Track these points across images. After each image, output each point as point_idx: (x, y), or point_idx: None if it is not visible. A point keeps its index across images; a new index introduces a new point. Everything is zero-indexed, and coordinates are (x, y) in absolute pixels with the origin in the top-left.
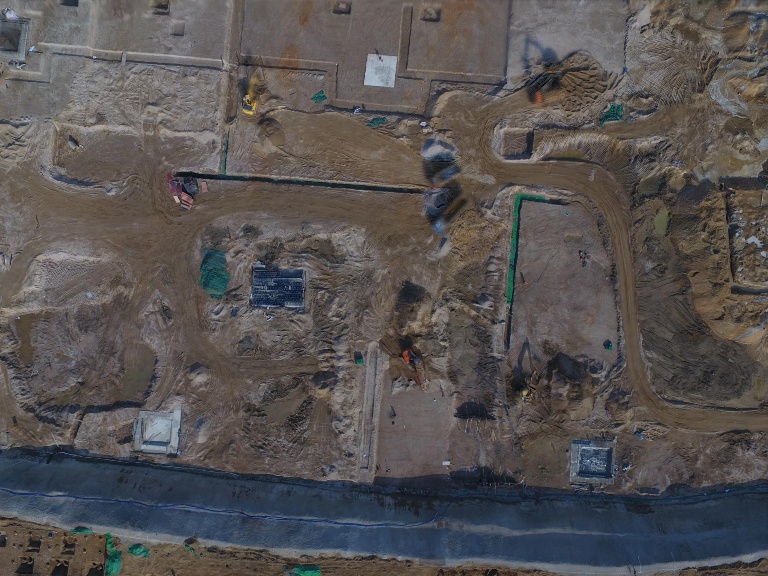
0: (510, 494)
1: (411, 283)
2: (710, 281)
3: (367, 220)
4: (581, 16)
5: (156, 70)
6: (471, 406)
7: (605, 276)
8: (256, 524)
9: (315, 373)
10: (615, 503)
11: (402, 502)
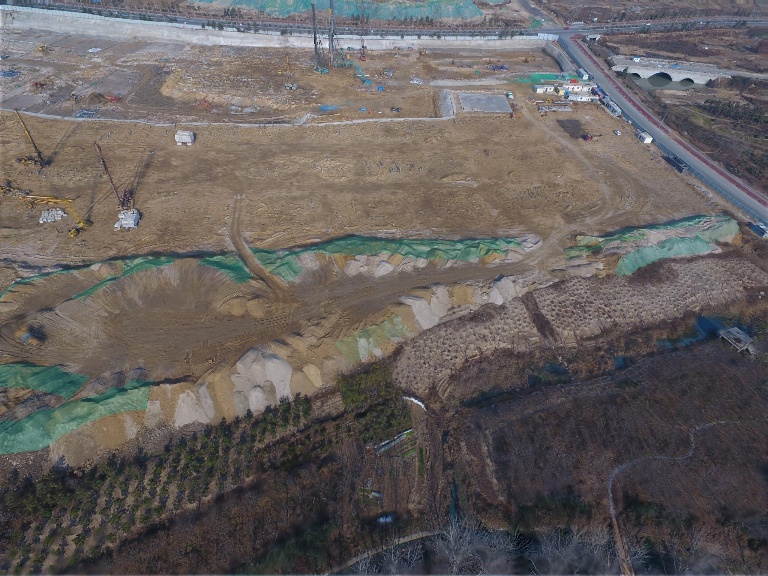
0: None
1: None
2: None
3: None
4: (169, 48)
5: None
6: None
7: None
8: None
9: None
10: None
11: None
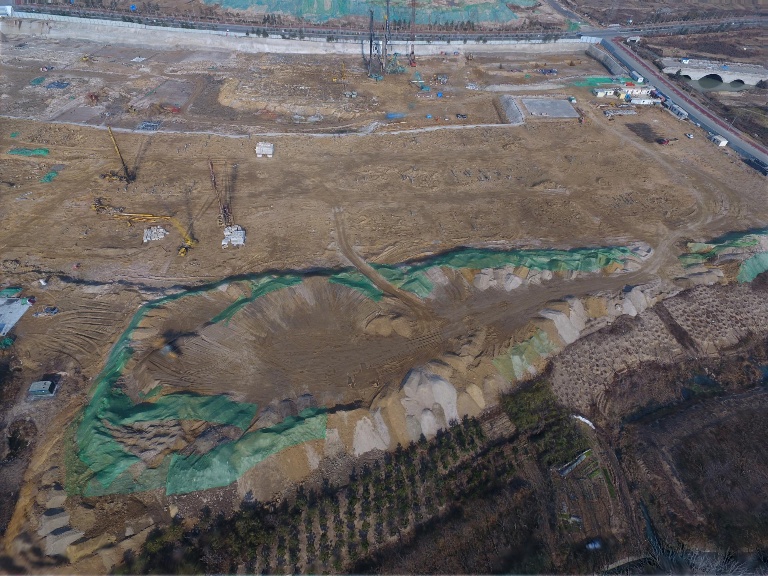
0: None
1: None
2: None
3: None
4: None
5: (62, 53)
6: None
7: None
8: None
9: None
10: None
11: None
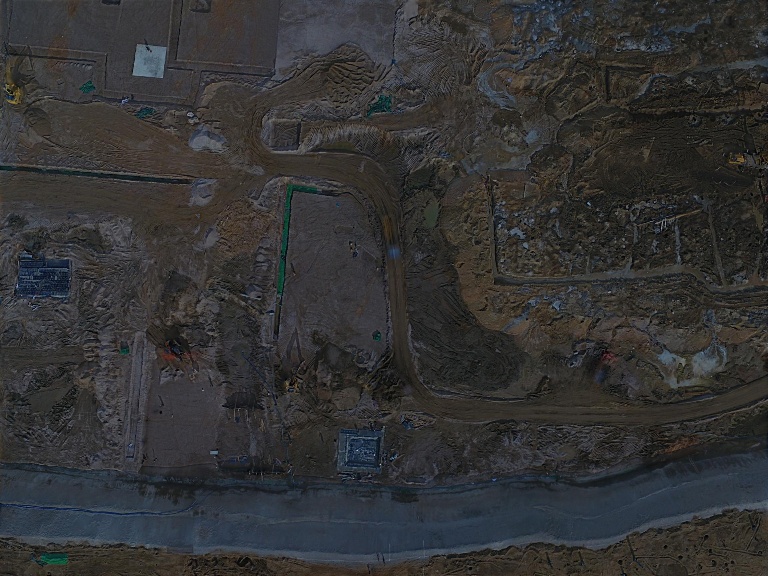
0: (278, 483)
1: (178, 273)
2: (473, 272)
3: (134, 210)
4: (350, 8)
5: None
6: (242, 396)
7: (376, 267)
8: (8, 512)
9: (81, 363)
10: (382, 492)
11: (164, 491)
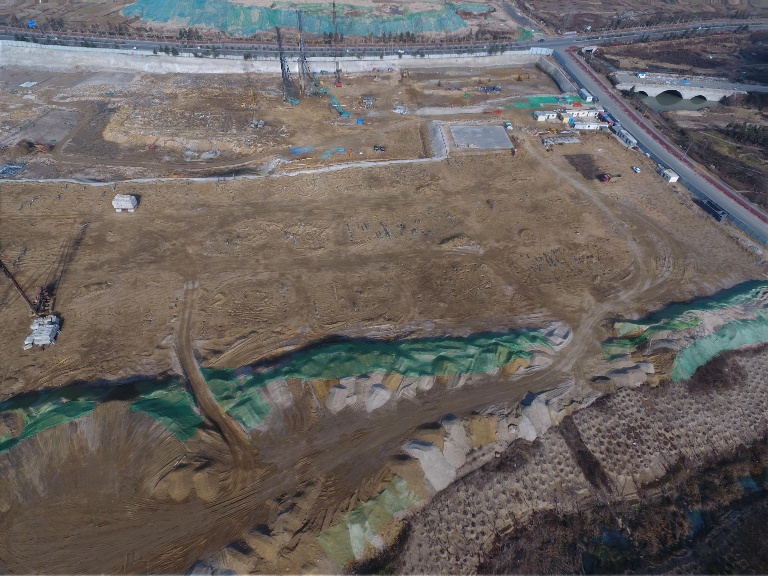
0: None
1: None
2: None
3: None
4: None
5: None
6: None
7: None
8: None
9: None
10: None
11: None
